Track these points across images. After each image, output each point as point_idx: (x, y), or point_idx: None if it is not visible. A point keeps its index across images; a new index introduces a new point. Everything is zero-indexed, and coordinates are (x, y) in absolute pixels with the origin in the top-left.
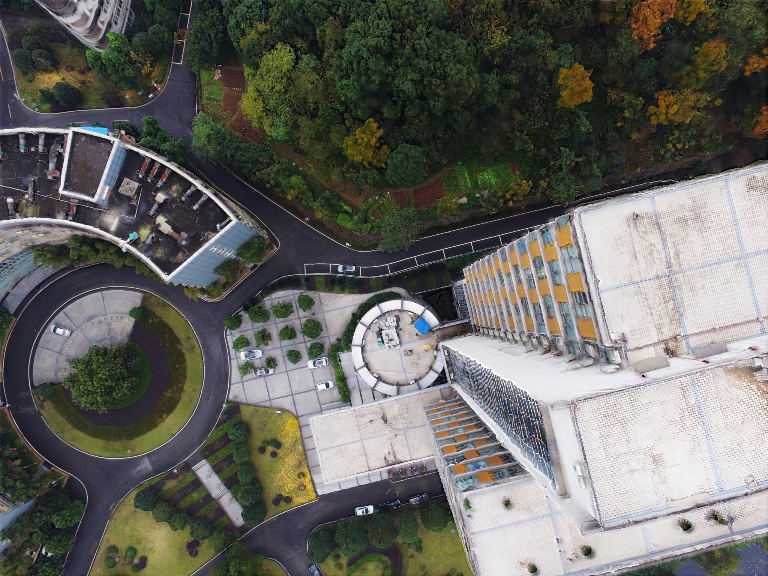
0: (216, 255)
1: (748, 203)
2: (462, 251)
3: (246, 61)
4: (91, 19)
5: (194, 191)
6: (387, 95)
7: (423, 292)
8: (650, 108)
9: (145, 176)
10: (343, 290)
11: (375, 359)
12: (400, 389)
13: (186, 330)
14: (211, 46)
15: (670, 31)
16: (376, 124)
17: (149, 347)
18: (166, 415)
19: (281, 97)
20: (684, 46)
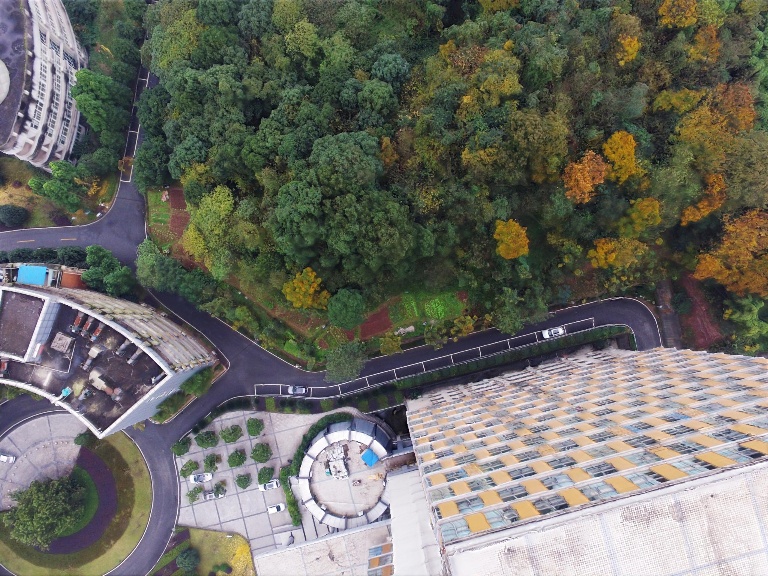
0: (155, 400)
1: (622, 535)
2: (413, 371)
3: (186, 200)
4: (34, 147)
5: (129, 345)
6: (325, 244)
7: (375, 412)
8: (590, 252)
9: (78, 331)
10: (294, 411)
11: (323, 489)
12: (348, 522)
13: (134, 453)
14: (156, 174)
15: (603, 190)
16: (314, 274)
17: (96, 472)
18: (114, 541)
19: (220, 240)
20: (618, 201)
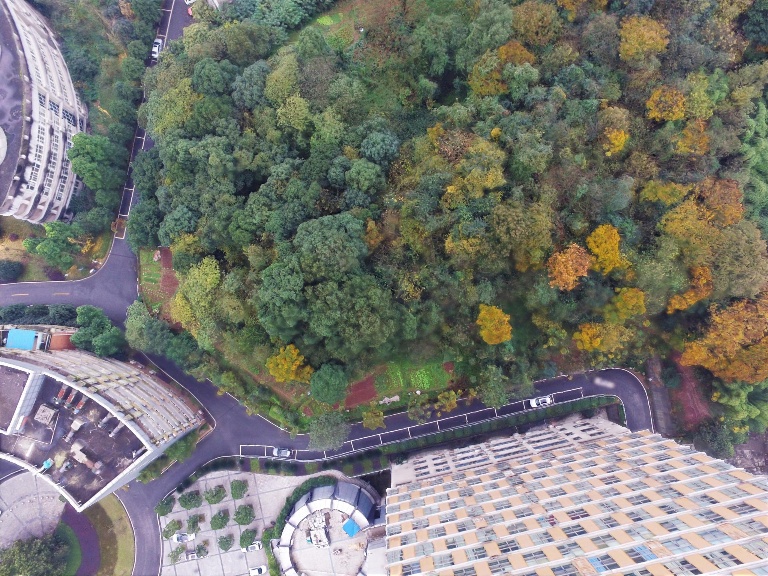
0: (137, 469)
1: None
2: (399, 437)
3: (175, 269)
4: (30, 206)
5: (111, 418)
6: None
7: (359, 476)
8: (575, 335)
9: (62, 403)
10: (278, 472)
11: (304, 558)
12: None
13: (118, 510)
14: (148, 236)
15: (587, 281)
16: (297, 351)
17: (80, 529)
18: None
19: (206, 311)
20: (603, 290)
